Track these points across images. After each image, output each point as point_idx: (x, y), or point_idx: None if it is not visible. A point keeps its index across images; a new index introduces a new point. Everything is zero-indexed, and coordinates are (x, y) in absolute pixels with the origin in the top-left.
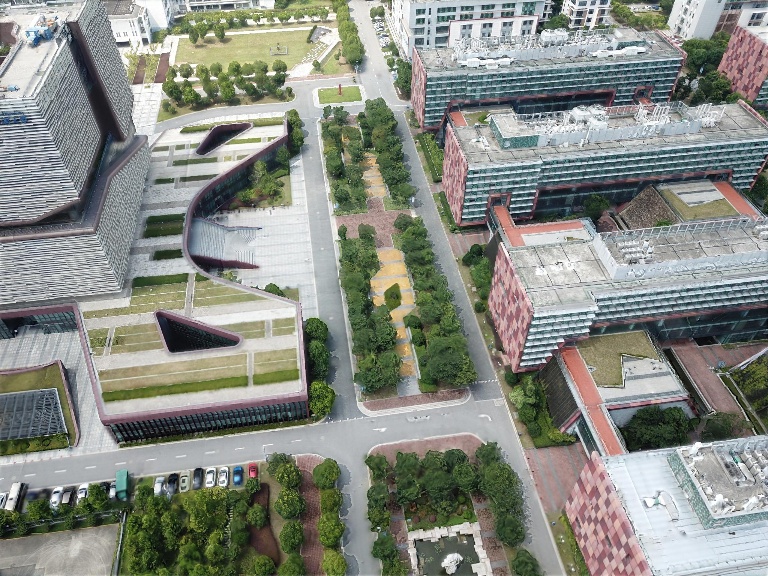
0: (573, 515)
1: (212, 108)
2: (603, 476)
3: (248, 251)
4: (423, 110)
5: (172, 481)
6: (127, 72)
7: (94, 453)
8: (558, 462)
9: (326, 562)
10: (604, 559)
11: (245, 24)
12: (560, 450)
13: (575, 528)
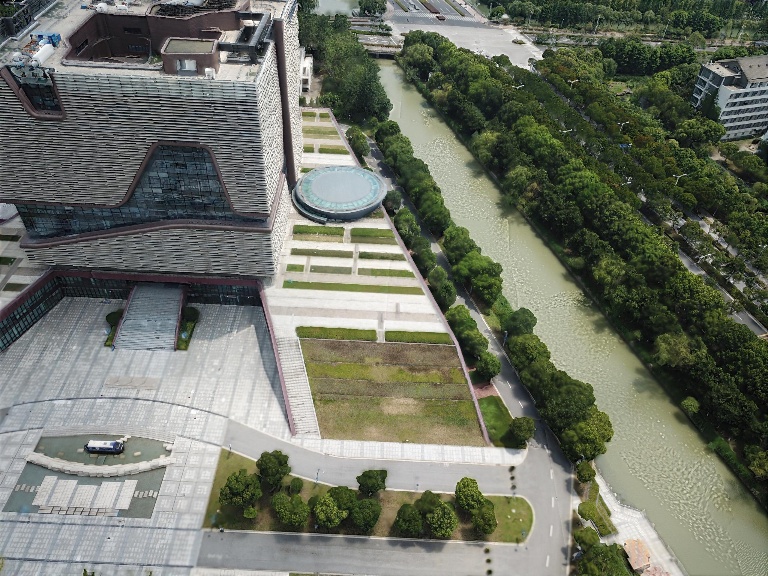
0: None
1: None
2: None
3: (6, 207)
4: None
5: None
6: None
7: None
8: None
9: None
10: None
11: None
12: None
13: None
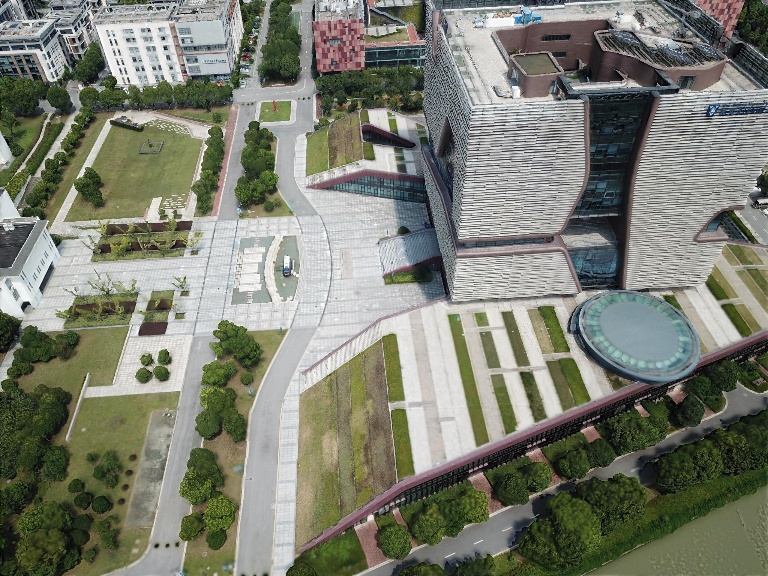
0: None
1: None
2: (706, 1)
3: None
4: None
5: None
6: (168, 243)
7: None
8: None
9: None
10: None
11: (58, 172)
12: None
13: None
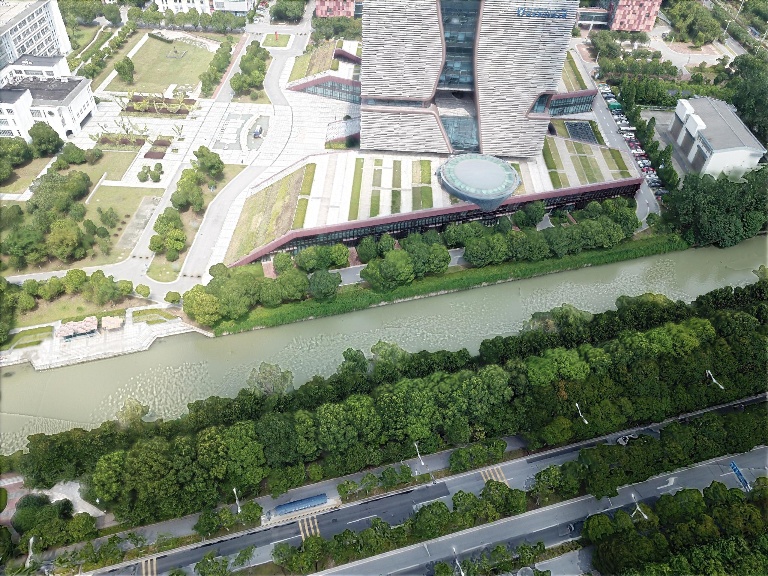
0: (618, 24)
1: (263, 83)
2: None
3: None
4: (353, 3)
5: (610, 97)
6: None
7: (597, 117)
8: (586, 34)
9: (644, 62)
10: (641, 13)
11: None
12: (581, 33)
13: (621, 27)
